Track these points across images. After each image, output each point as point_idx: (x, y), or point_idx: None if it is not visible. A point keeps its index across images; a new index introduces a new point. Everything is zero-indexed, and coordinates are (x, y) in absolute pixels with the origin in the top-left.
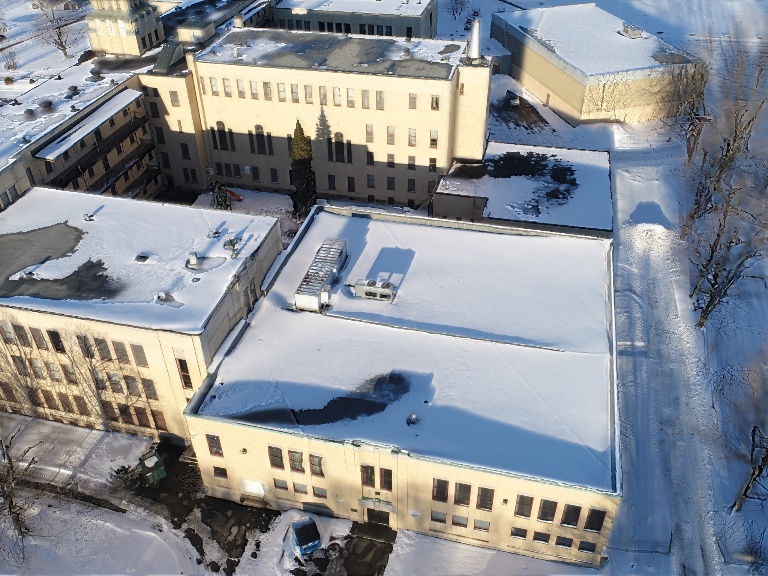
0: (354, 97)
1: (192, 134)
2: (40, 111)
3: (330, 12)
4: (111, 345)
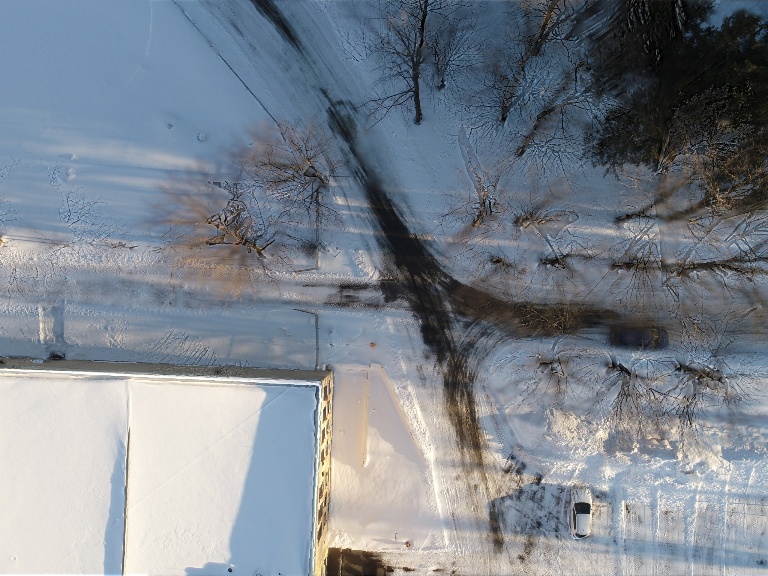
0: None
1: None
2: None
3: None
4: None
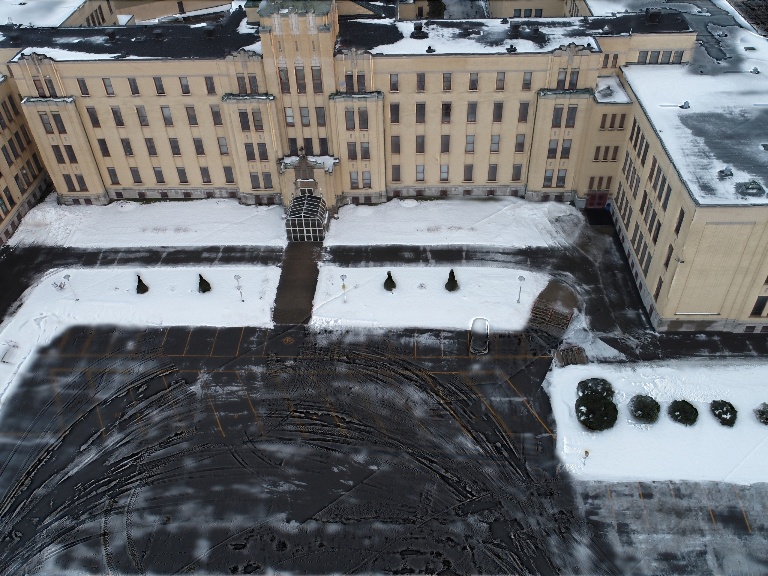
0: None
1: None
2: (518, 36)
3: (68, 20)
4: None
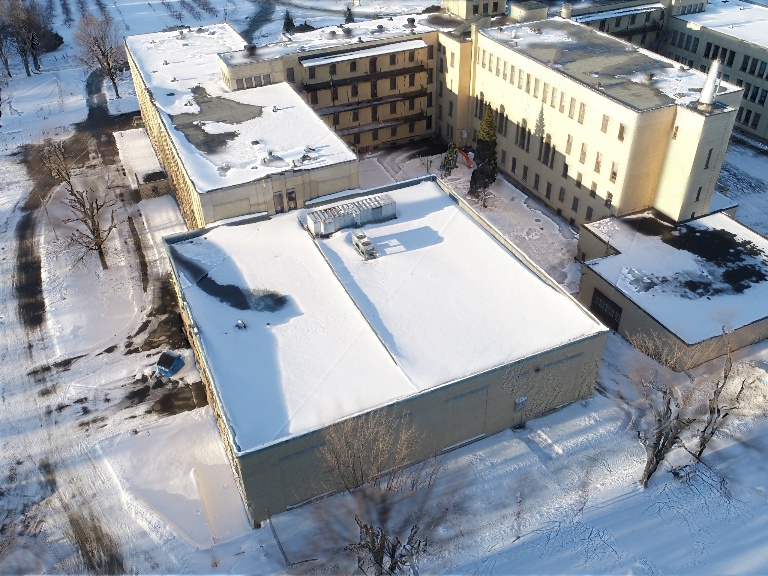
0: (565, 102)
1: (456, 95)
2: (344, 35)
3: (721, 34)
4: (186, 182)
